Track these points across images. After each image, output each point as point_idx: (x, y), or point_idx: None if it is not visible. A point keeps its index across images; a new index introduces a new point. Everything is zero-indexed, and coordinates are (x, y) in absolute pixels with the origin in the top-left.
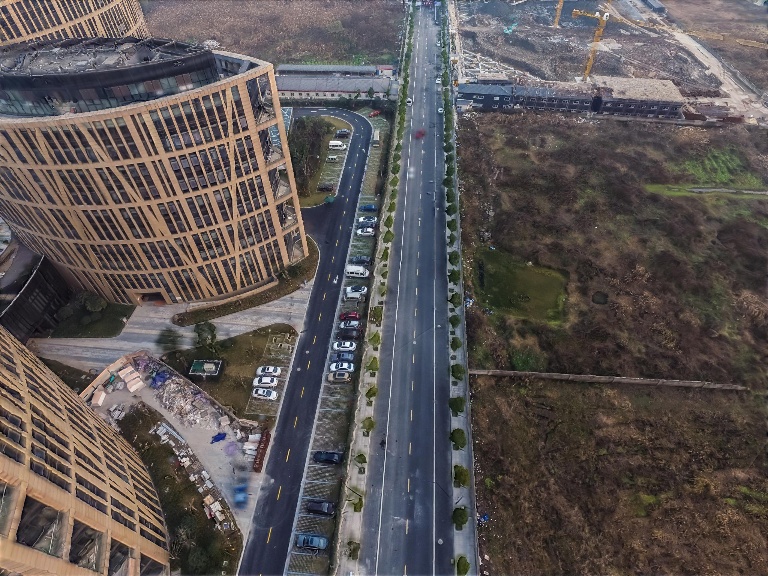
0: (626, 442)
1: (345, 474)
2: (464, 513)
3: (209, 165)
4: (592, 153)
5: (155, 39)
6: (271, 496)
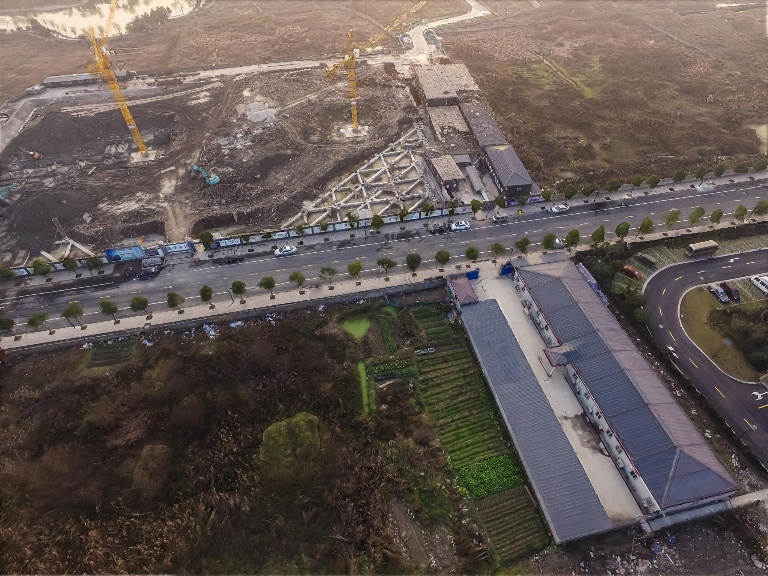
0: None
1: None
2: None
3: None
4: (573, 111)
5: None
6: None
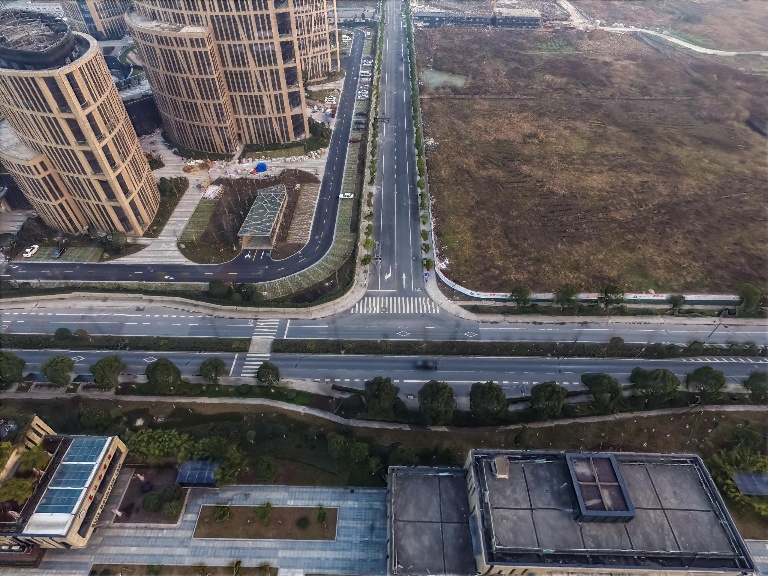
0: (483, 109)
1: (369, 115)
2: (416, 113)
3: (306, 1)
4: None
5: None
6: (340, 122)
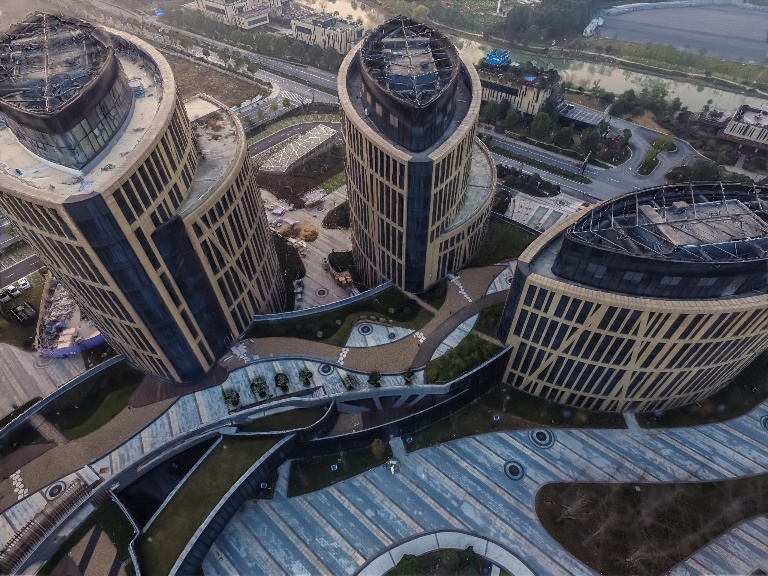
0: None
1: None
2: None
3: None
4: None
5: None
6: None
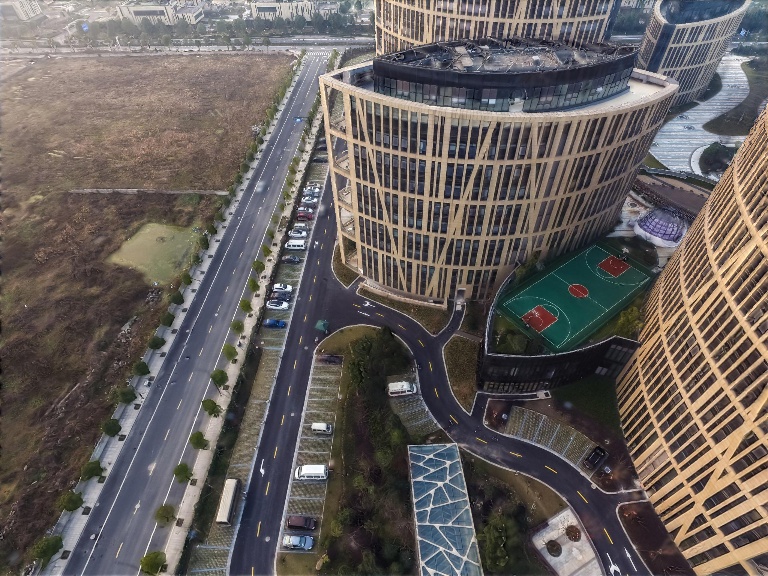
0: None
1: None
2: (258, 137)
3: None
4: None
5: (446, 70)
6: None
